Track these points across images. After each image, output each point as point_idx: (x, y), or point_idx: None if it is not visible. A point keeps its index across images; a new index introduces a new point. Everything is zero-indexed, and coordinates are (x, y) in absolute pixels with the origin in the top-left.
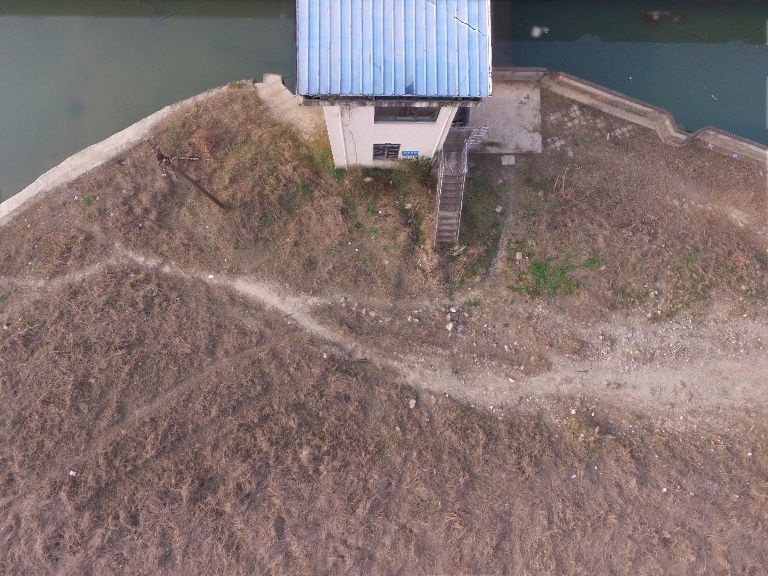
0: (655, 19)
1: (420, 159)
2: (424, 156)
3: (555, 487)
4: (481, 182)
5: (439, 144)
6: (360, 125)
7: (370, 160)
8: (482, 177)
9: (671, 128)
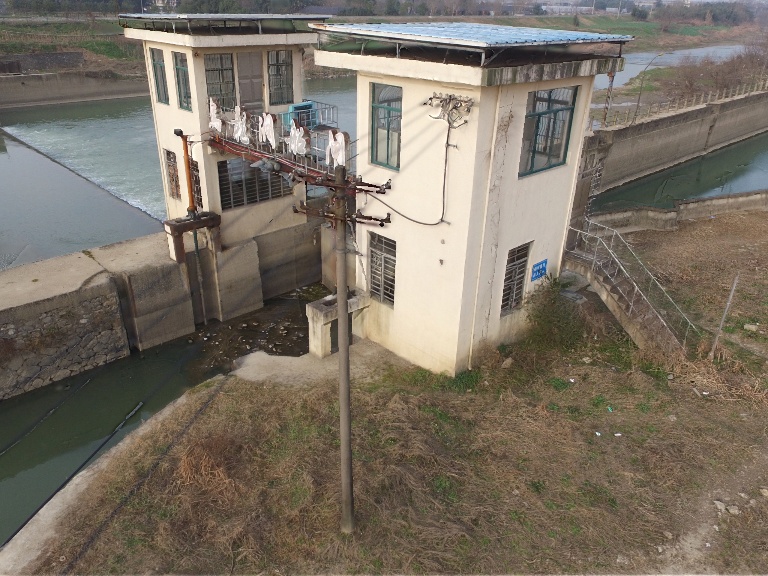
0: None
1: (550, 280)
2: (551, 274)
3: None
4: (607, 310)
5: (566, 228)
6: (504, 188)
7: (497, 319)
8: (601, 307)
9: (659, 214)
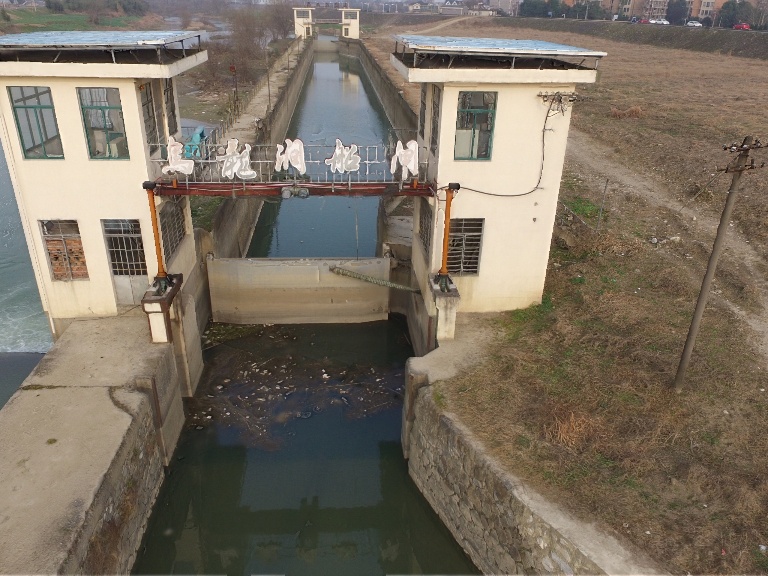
0: (279, 226)
1: None
2: None
3: (767, 200)
4: None
5: None
6: None
7: None
8: None
9: None
